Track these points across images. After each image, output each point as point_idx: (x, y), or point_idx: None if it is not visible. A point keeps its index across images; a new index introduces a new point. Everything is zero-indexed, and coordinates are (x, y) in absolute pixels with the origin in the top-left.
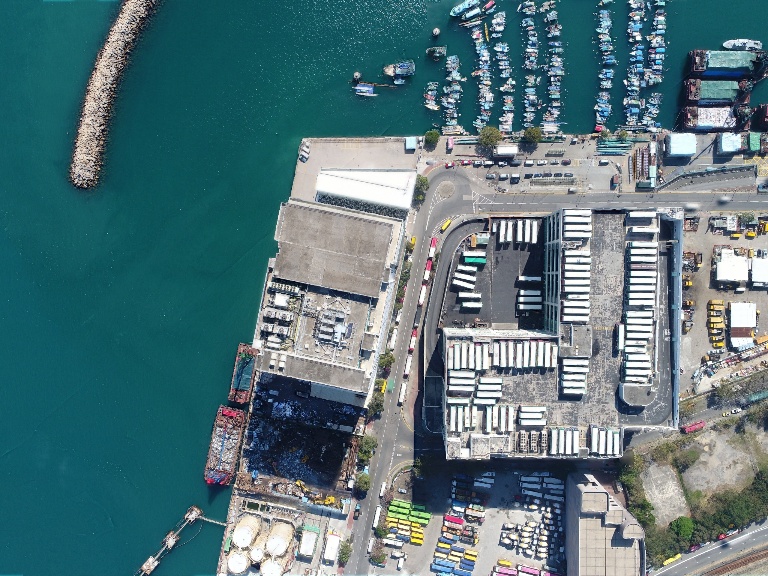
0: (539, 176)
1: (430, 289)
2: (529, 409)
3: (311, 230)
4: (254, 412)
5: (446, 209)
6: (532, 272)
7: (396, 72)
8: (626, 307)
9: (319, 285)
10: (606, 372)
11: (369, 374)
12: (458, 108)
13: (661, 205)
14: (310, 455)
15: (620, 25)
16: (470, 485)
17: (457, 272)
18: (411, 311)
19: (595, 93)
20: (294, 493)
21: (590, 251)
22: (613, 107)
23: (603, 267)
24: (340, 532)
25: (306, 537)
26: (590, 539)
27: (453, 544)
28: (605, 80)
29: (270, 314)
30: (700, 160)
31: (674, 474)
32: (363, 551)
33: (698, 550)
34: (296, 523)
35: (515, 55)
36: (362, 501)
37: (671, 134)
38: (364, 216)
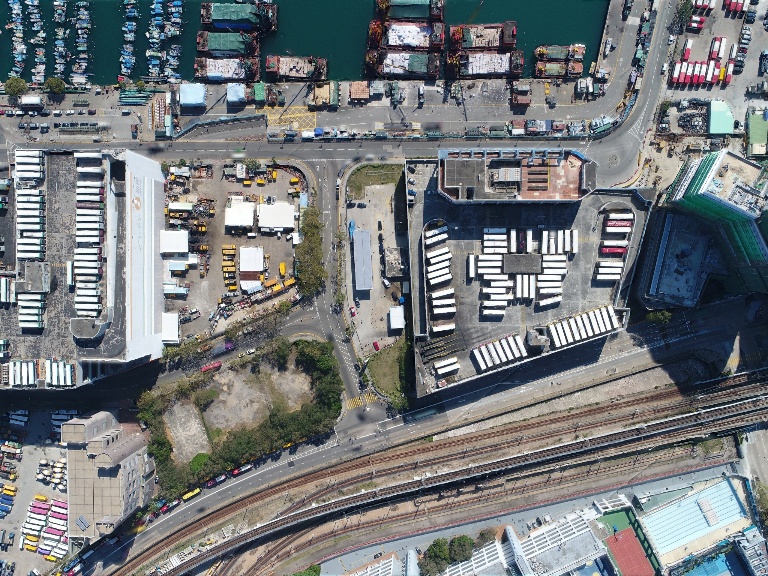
0: (66, 125)
1: None
2: None
3: None
4: None
5: None
6: None
7: None
8: (81, 245)
9: None
10: (64, 307)
11: None
12: None
13: (179, 153)
14: None
15: None
16: (6, 423)
17: None
18: None
19: (120, 45)
20: None
21: (40, 190)
22: (137, 59)
23: (59, 206)
24: None
25: None
26: (78, 470)
27: None
28: (128, 33)
29: None
30: (215, 110)
31: (197, 413)
32: None
33: (219, 485)
34: None
35: (45, 8)
36: None
37: (181, 84)
38: None
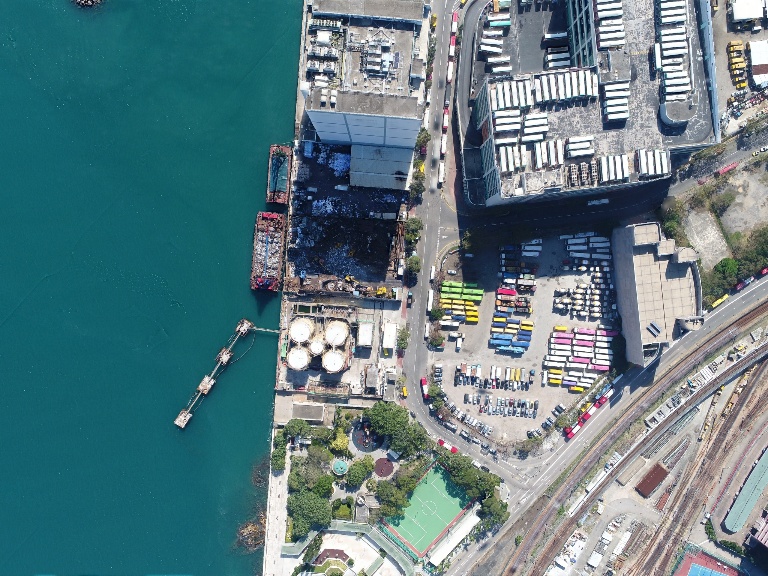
0: None
1: (456, 66)
2: (577, 139)
3: None
4: (294, 213)
5: None
6: (556, 31)
7: None
8: (658, 29)
9: (361, 15)
10: (646, 96)
11: None
12: None
13: None
14: (356, 248)
15: None
16: (518, 256)
17: (483, 38)
18: (440, 91)
19: None
20: (345, 289)
21: None
22: None
23: None
24: None
25: (363, 328)
26: (645, 275)
27: (508, 318)
28: None
29: (315, 49)
30: None
31: (713, 219)
32: (420, 338)
33: (743, 290)
34: (350, 319)
35: None
36: (413, 288)
37: None
38: None
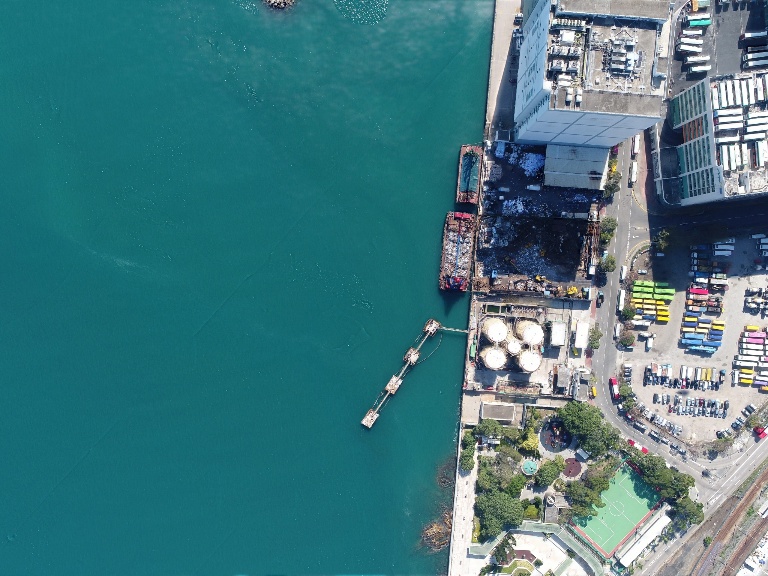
0: None
1: None
2: None
3: None
4: (484, 213)
5: None
6: (754, 30)
7: None
8: None
9: (607, 14)
10: None
11: None
12: None
13: None
14: (547, 248)
15: None
16: (710, 255)
17: (682, 38)
18: None
19: None
20: (535, 289)
21: None
22: None
23: None
24: (584, 322)
25: (556, 328)
26: None
27: (699, 317)
28: None
29: (562, 49)
30: None
31: None
32: (609, 338)
33: None
34: (539, 319)
35: None
36: (603, 288)
37: None
38: None
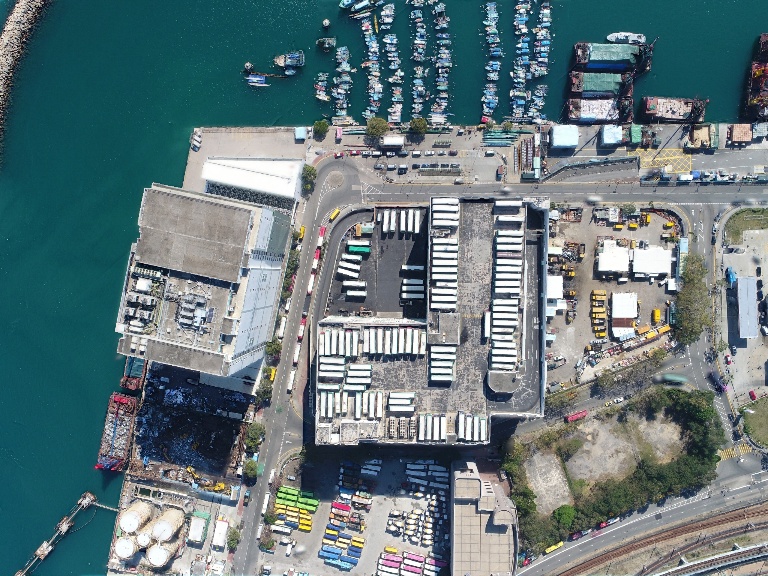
0: (426, 166)
1: None
2: (397, 395)
3: (172, 215)
4: (146, 399)
5: (335, 199)
6: (416, 261)
7: (286, 63)
8: (494, 295)
9: (179, 270)
10: (475, 359)
11: (231, 358)
12: (348, 99)
13: None
14: (201, 442)
15: (507, 18)
16: (357, 472)
17: (342, 261)
18: (301, 300)
19: (482, 85)
20: (185, 479)
21: (457, 239)
22: (500, 99)
23: (472, 255)
24: (230, 518)
25: (194, 523)
26: (465, 525)
27: (341, 531)
28: (492, 72)
29: (131, 298)
30: (584, 152)
31: (558, 463)
32: (253, 537)
33: (581, 538)
34: (187, 509)
35: (404, 47)
36: (252, 488)
37: (554, 126)
38: (226, 202)
